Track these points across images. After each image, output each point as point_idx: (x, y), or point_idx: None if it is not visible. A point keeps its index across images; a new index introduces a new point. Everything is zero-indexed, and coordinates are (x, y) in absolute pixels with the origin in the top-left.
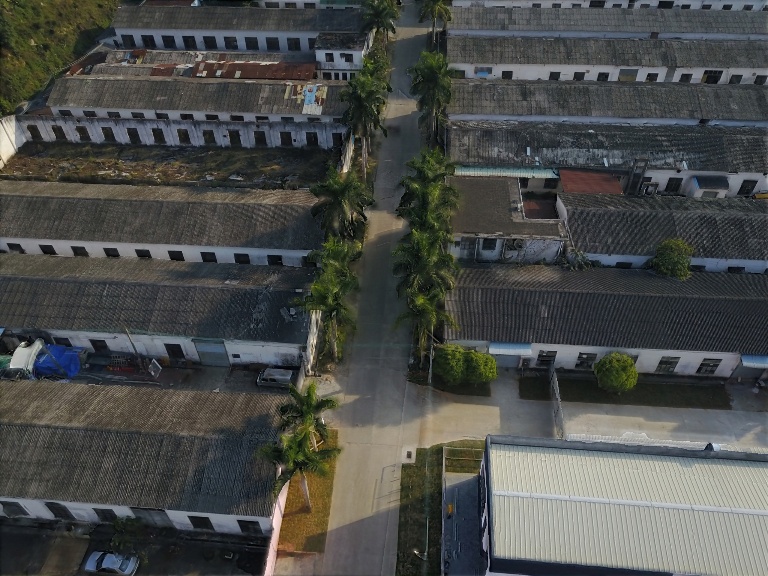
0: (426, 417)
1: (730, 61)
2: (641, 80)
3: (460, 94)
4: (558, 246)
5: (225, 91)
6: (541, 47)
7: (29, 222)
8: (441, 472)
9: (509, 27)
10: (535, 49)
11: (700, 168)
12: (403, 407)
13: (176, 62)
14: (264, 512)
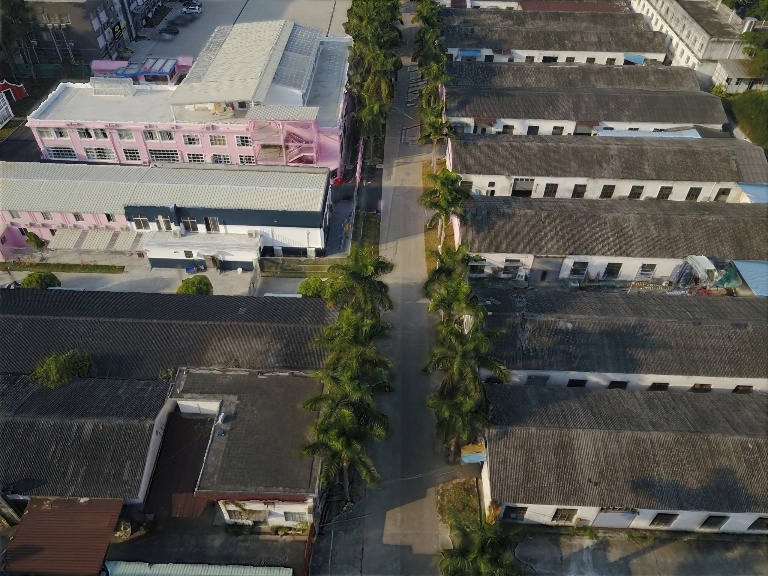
0: None
1: None
2: None
3: None
4: None
5: None
6: None
7: None
8: None
9: None
10: None
11: None
12: None
13: None
14: None
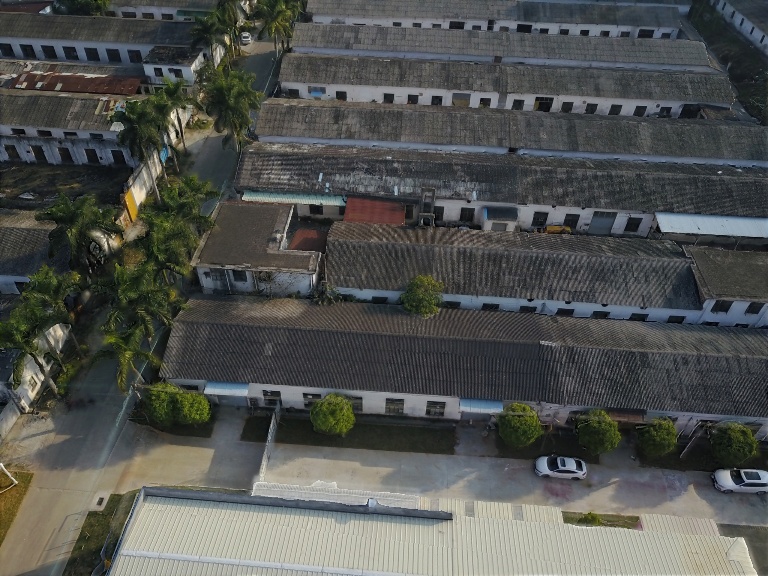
0: (133, 460)
1: (560, 88)
2: (475, 104)
3: (272, 115)
4: (309, 279)
5: (34, 105)
6: (376, 68)
7: None
8: (124, 521)
9: (353, 46)
10: (369, 70)
11: (489, 199)
12: (113, 449)
13: (3, 72)
14: None
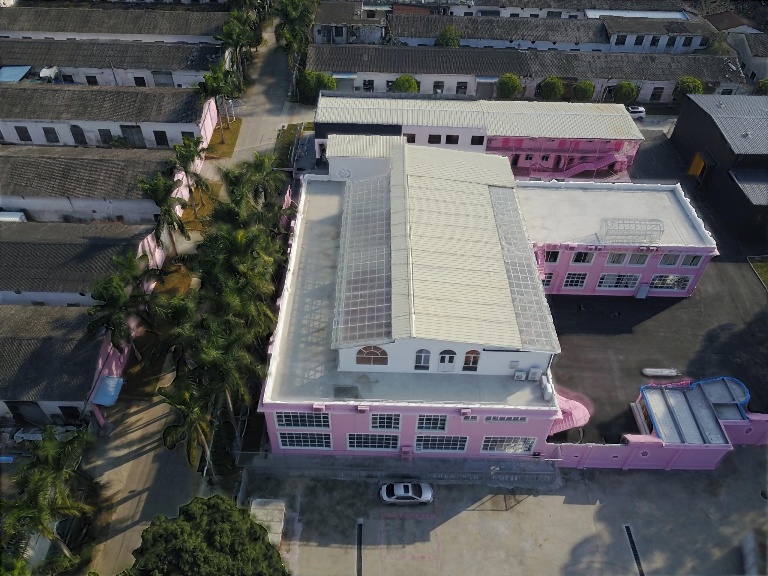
0: (295, 113)
1: None
2: None
3: None
4: (381, 32)
5: None
6: None
7: (37, 22)
8: (301, 130)
9: None
10: None
11: (482, 4)
12: (282, 110)
13: None
14: (196, 122)
